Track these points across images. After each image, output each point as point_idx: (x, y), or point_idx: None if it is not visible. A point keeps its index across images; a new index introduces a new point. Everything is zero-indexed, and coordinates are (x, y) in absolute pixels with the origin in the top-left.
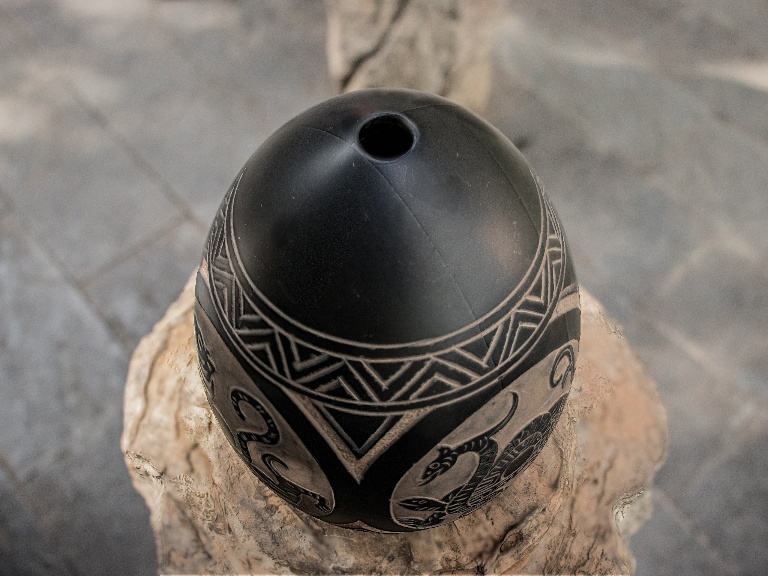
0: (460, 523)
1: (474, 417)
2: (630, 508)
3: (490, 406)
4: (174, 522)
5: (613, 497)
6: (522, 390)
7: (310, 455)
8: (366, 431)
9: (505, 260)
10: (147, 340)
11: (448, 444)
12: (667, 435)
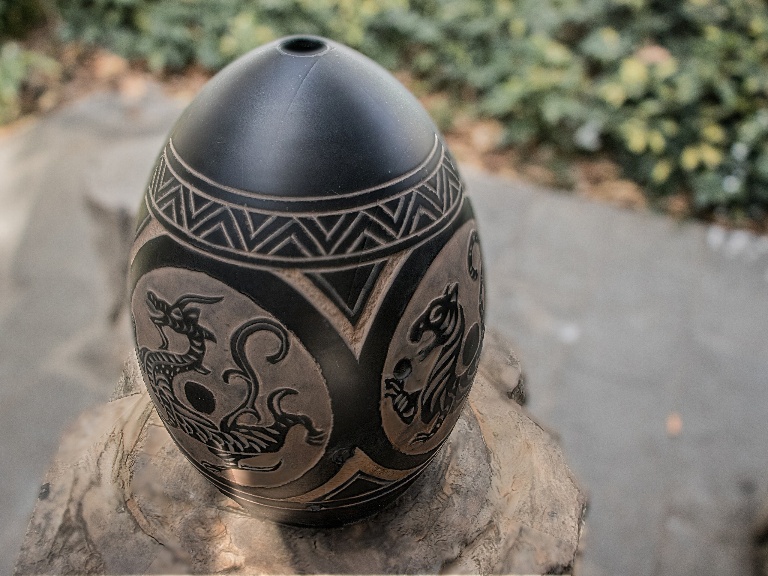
0: None
1: None
2: None
3: None
4: (515, 575)
5: None
6: None
7: None
8: None
9: None
10: None
11: None
12: None
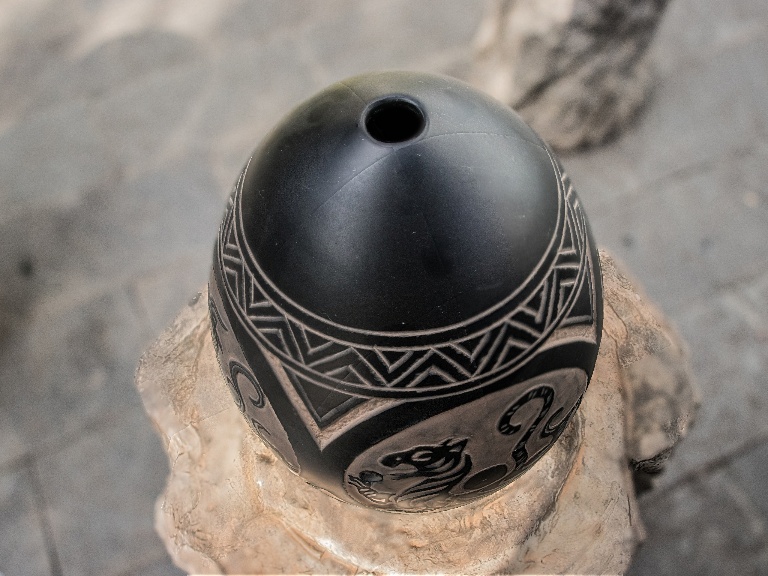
0: None
1: None
2: None
3: None
4: None
5: None
6: None
7: (574, 370)
8: (587, 296)
9: None
10: None
11: None
12: None
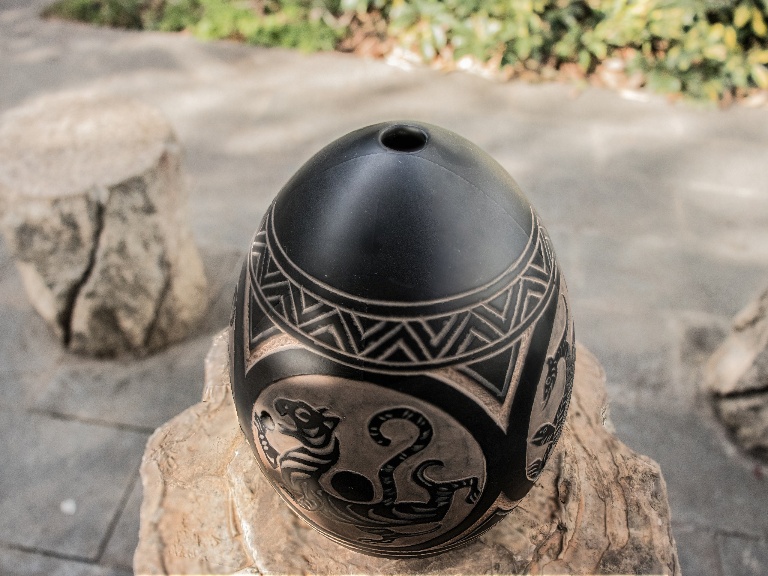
0: (521, 503)
1: (555, 322)
2: (607, 423)
3: (559, 309)
4: None
5: (597, 416)
6: (564, 293)
7: (463, 430)
8: (503, 370)
9: (517, 192)
10: (140, 551)
11: (550, 355)
12: (592, 356)
